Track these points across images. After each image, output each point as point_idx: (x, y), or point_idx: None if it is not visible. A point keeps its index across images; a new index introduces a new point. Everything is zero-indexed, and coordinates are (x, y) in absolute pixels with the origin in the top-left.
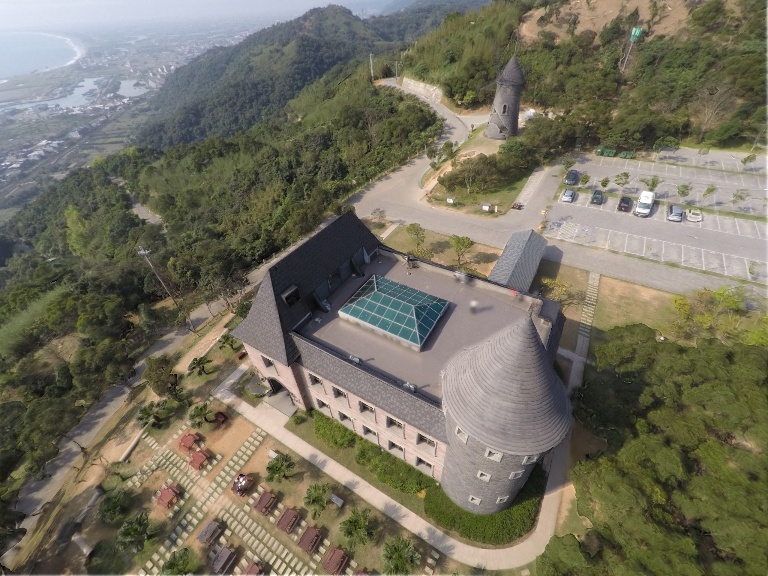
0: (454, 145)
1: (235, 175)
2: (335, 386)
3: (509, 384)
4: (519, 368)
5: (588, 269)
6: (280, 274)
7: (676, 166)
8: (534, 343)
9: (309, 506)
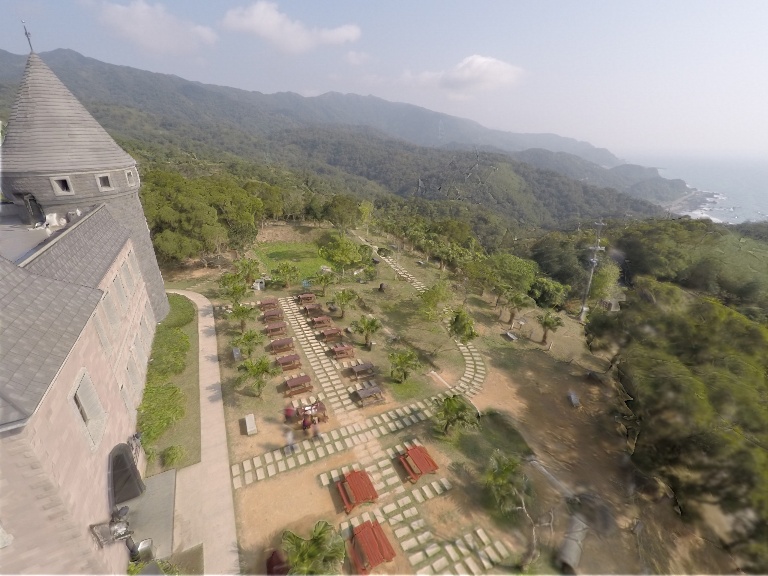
0: None
1: None
2: None
3: (86, 112)
4: None
5: None
6: None
7: None
8: None
9: None
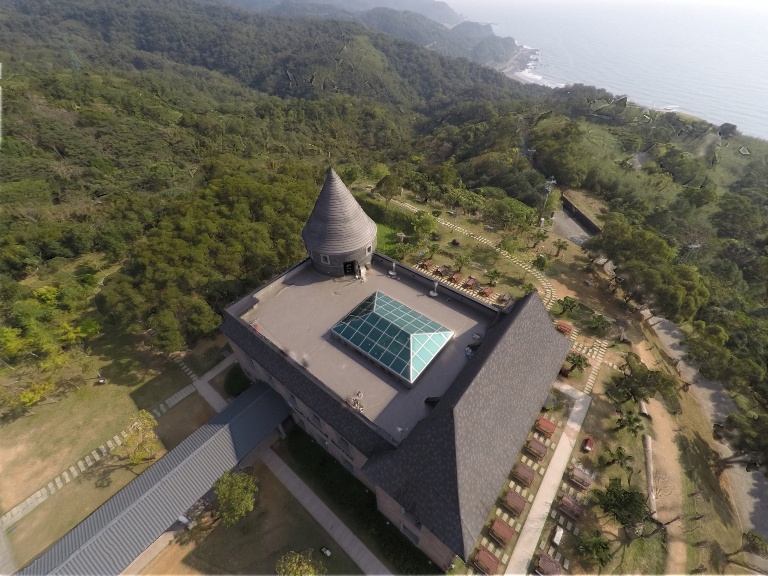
0: None
1: None
2: None
3: None
4: None
5: None
6: None
7: None
8: None
9: None
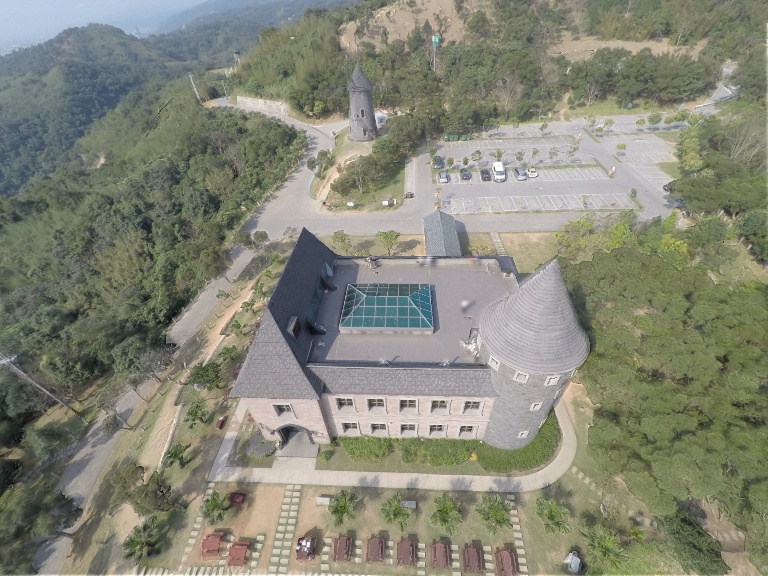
0: (327, 153)
1: (57, 238)
2: (371, 398)
3: (553, 317)
4: (558, 302)
5: (487, 231)
6: (277, 309)
7: (502, 140)
8: (562, 278)
9: (392, 523)
